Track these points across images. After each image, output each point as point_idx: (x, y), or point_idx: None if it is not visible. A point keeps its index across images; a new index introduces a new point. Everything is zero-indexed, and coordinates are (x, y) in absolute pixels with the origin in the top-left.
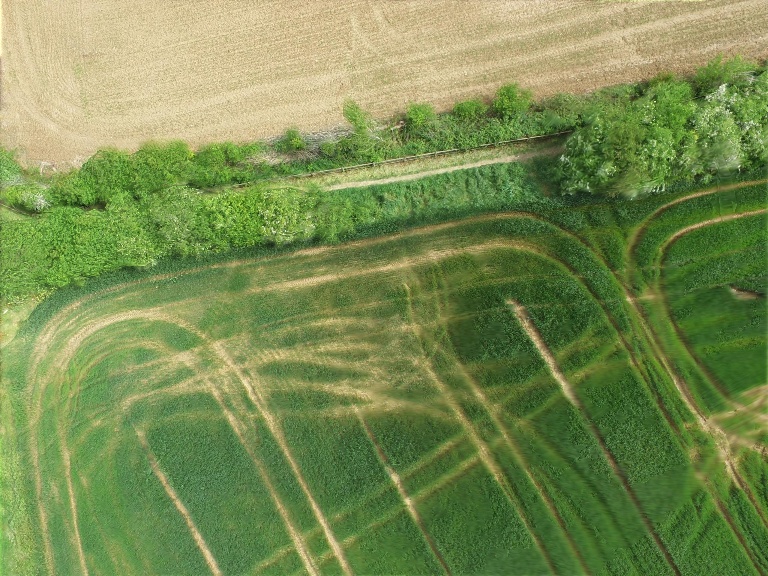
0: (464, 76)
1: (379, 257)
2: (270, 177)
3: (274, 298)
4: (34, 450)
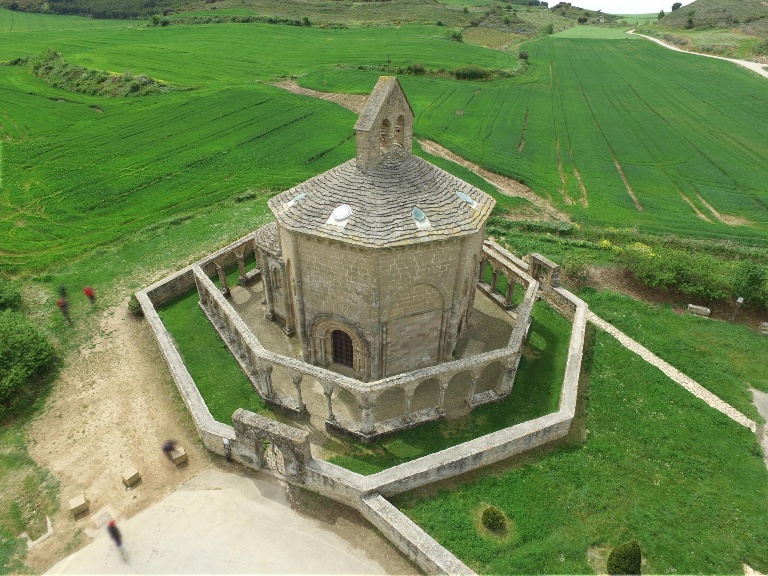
0: None
1: None
2: None
3: None
4: None
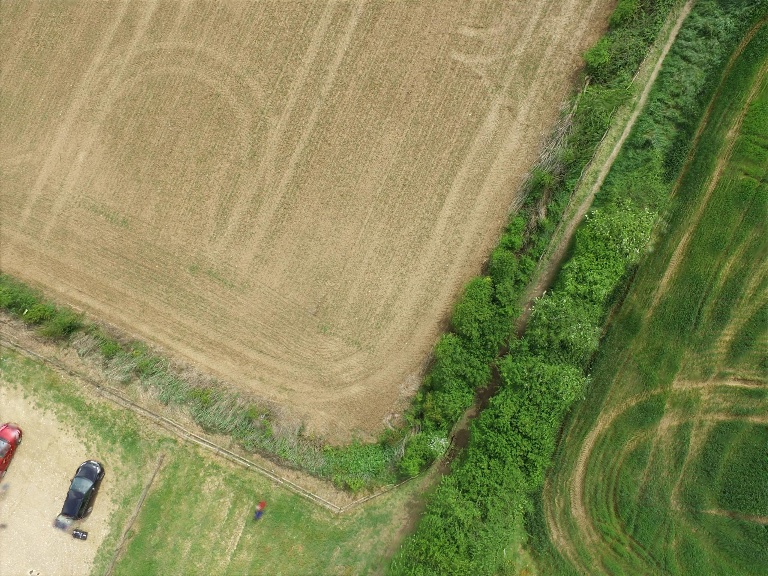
0: None
1: (702, 182)
2: (555, 227)
3: (672, 301)
4: None
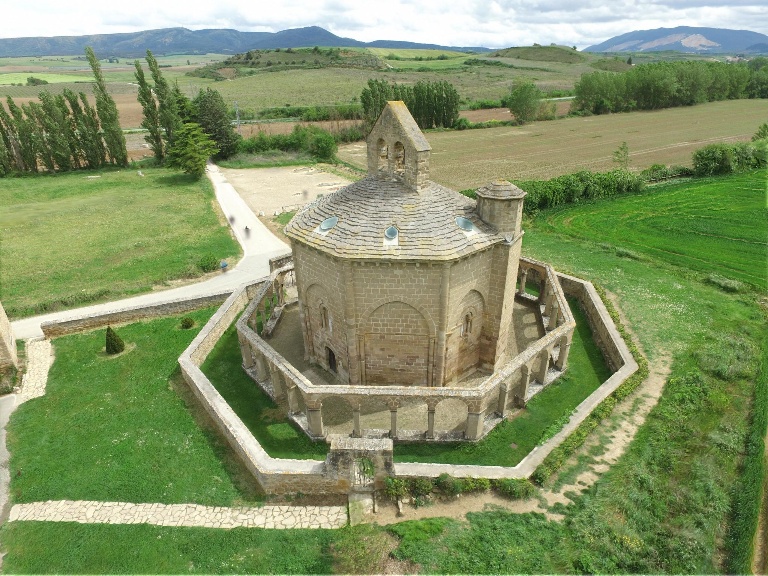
0: None
1: None
2: None
3: None
4: None
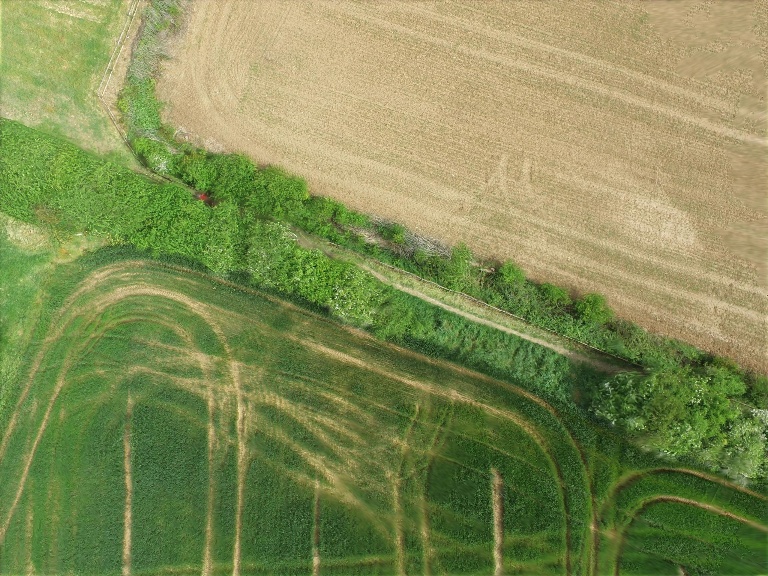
0: (566, 260)
1: (409, 371)
2: (359, 252)
3: (304, 354)
4: (37, 363)
